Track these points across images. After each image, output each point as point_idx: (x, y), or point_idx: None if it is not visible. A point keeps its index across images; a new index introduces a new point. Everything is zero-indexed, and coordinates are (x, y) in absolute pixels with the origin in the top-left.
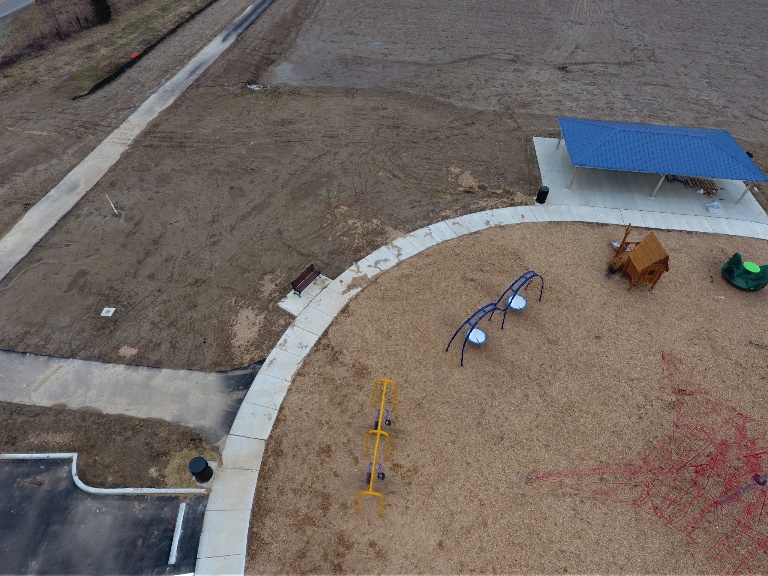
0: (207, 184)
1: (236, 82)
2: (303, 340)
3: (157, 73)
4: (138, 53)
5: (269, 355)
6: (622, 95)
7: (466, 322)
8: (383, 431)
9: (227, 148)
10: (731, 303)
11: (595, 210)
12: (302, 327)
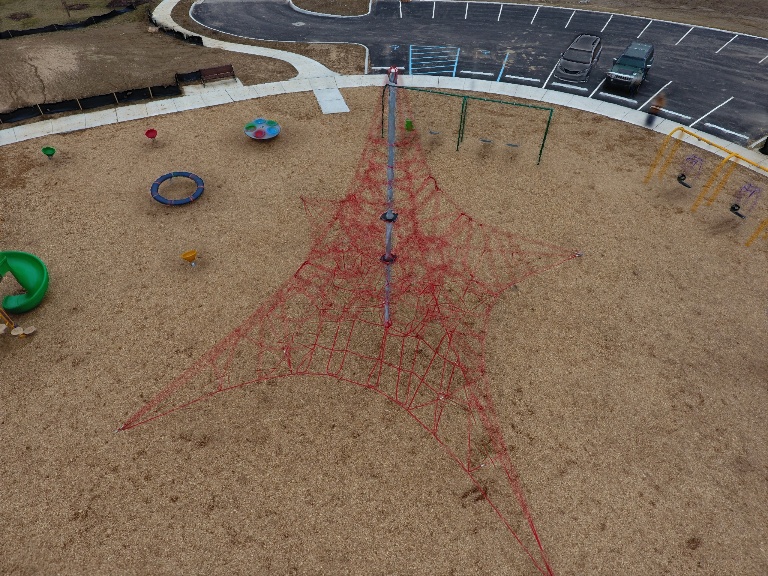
0: None
1: None
2: None
3: None
4: None
5: None
6: None
7: None
8: None
9: None
10: None
11: None
12: None
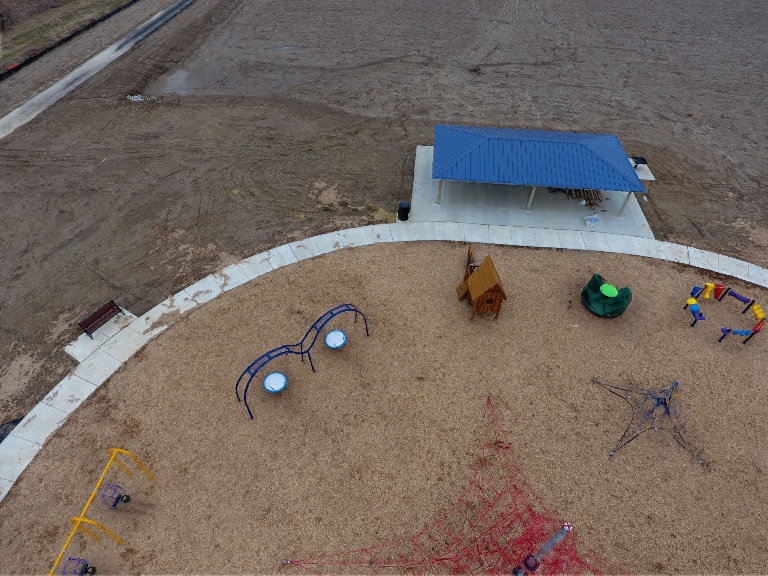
0: (35, 208)
1: (116, 93)
2: (77, 392)
3: (30, 85)
4: (17, 64)
5: (30, 412)
6: (530, 97)
7: (246, 370)
8: (86, 518)
9: (74, 166)
10: (584, 332)
11: (461, 227)
12: (81, 376)
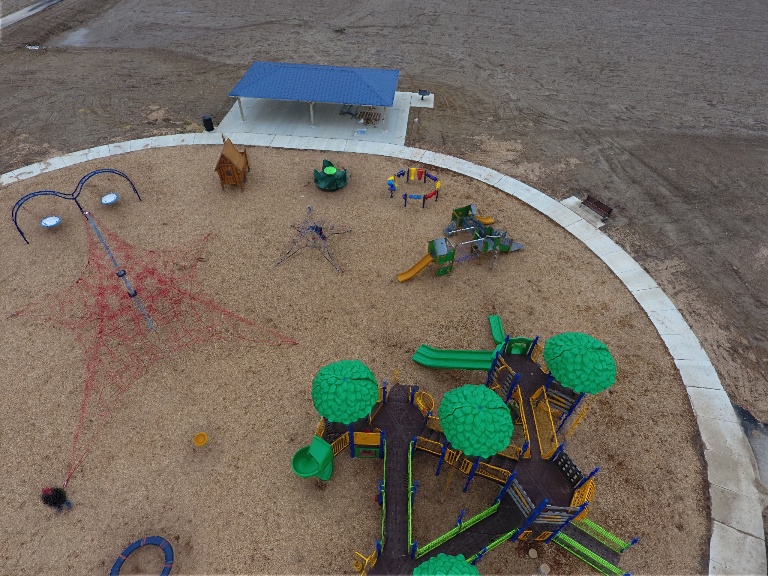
0: None
1: (16, 43)
2: None
3: None
4: None
5: None
6: (375, 51)
7: (16, 203)
8: None
9: None
10: (306, 200)
11: (252, 136)
12: None
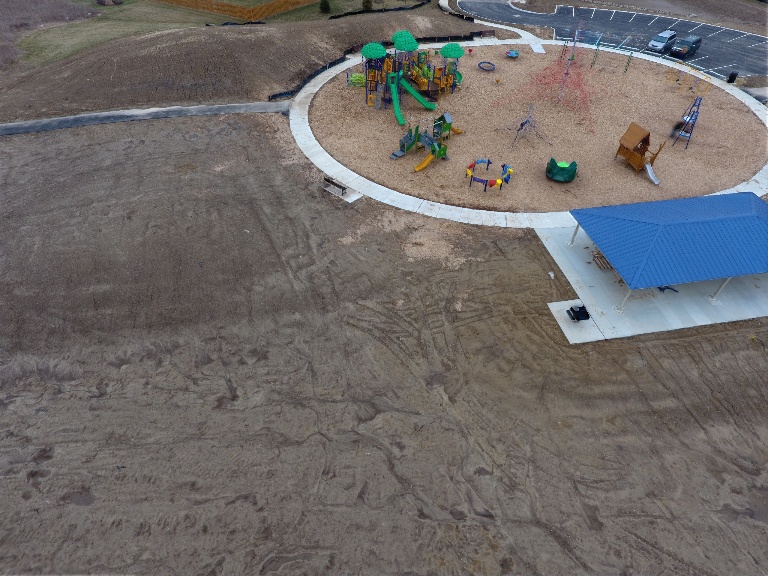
0: None
1: None
2: (760, 111)
3: None
4: None
5: None
6: None
7: None
8: (692, 69)
9: None
10: None
11: None
12: None
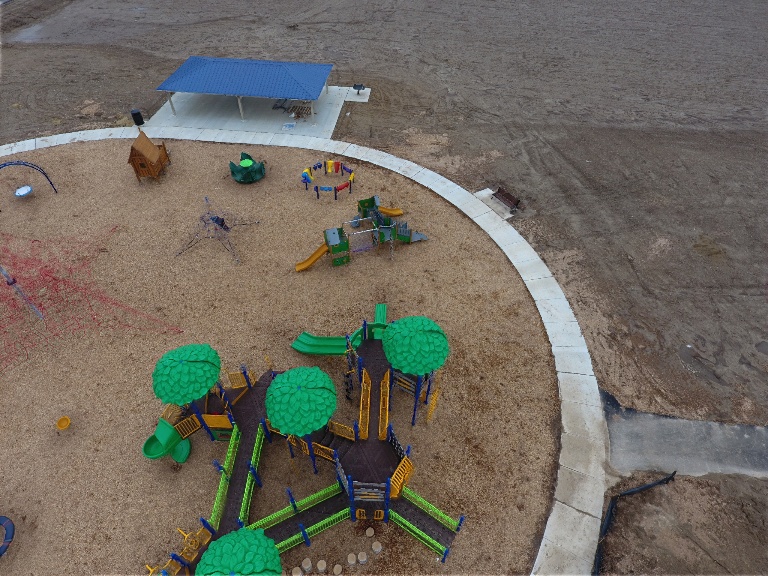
0: None
1: None
2: None
3: None
4: None
5: None
6: (323, 47)
7: None
8: None
9: None
10: (221, 192)
11: (181, 130)
12: None
